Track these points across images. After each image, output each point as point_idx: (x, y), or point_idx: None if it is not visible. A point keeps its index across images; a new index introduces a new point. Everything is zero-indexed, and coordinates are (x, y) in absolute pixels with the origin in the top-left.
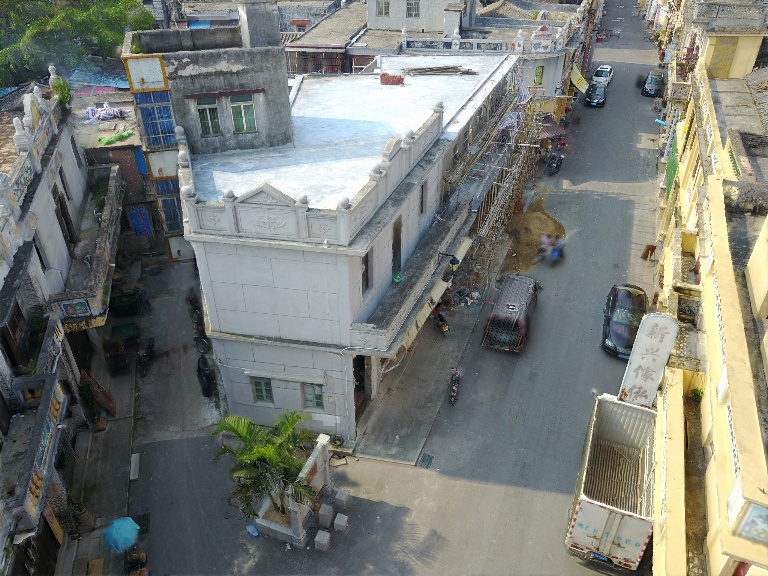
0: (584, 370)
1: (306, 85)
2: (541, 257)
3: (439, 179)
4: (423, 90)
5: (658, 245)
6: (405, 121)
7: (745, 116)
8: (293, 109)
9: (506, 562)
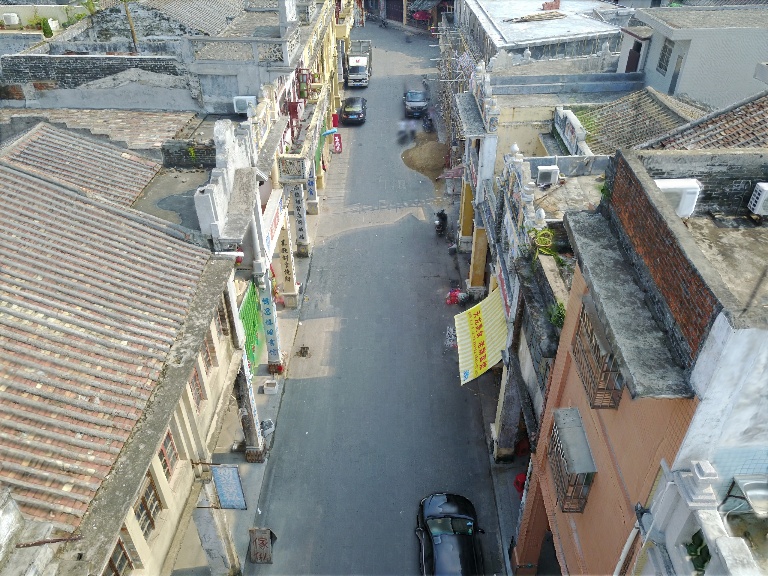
0: (373, 101)
1: (606, 4)
2: (414, 141)
3: (468, 24)
4: (521, 8)
5: (329, 155)
6: None
7: None
8: None
9: (388, 67)
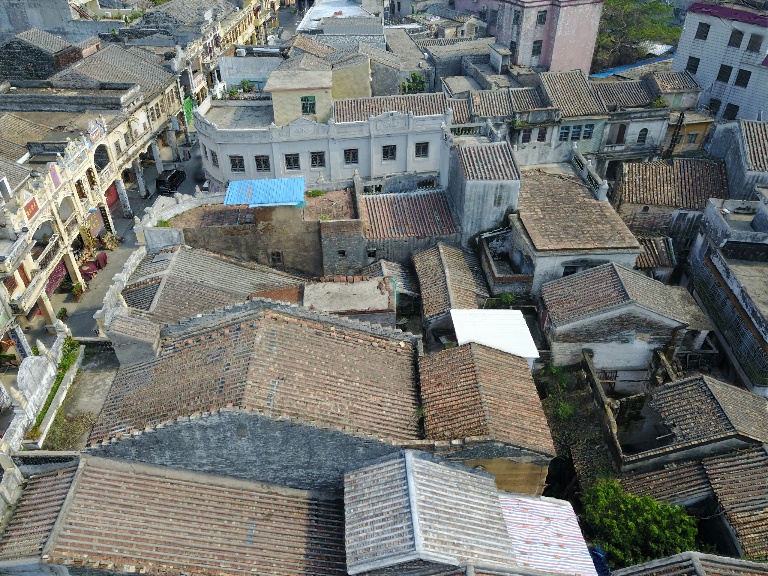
0: None
1: None
2: None
3: None
4: (326, 14)
5: None
6: (325, 7)
7: (224, 23)
8: (359, 7)
9: None
